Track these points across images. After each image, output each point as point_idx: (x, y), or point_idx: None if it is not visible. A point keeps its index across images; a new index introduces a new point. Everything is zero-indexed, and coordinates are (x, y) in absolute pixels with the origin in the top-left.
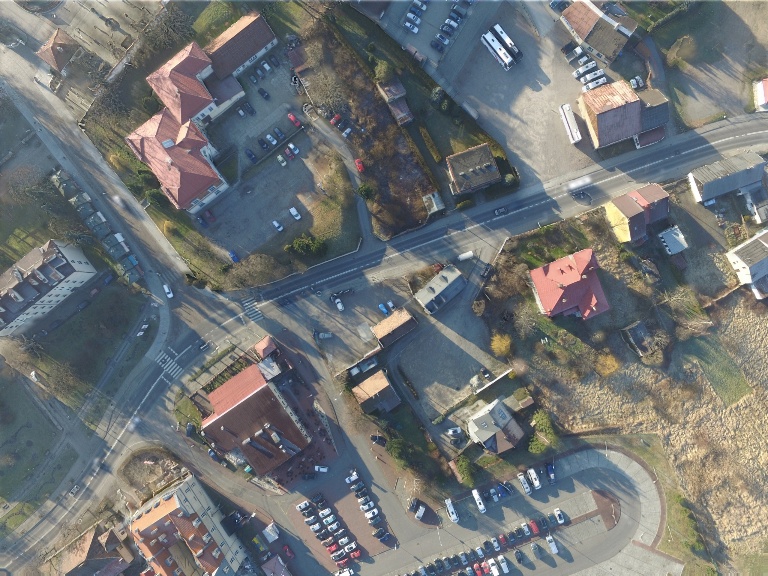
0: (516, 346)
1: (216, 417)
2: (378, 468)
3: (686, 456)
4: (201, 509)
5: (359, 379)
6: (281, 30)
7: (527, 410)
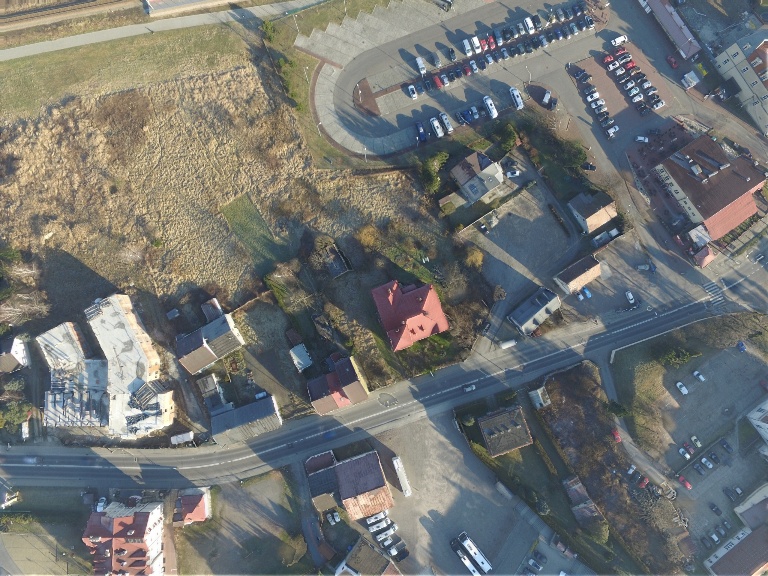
0: (454, 255)
1: (751, 190)
2: (587, 140)
3: (288, 147)
4: (766, 103)
5: (608, 225)
6: (700, 575)
7: (442, 193)
